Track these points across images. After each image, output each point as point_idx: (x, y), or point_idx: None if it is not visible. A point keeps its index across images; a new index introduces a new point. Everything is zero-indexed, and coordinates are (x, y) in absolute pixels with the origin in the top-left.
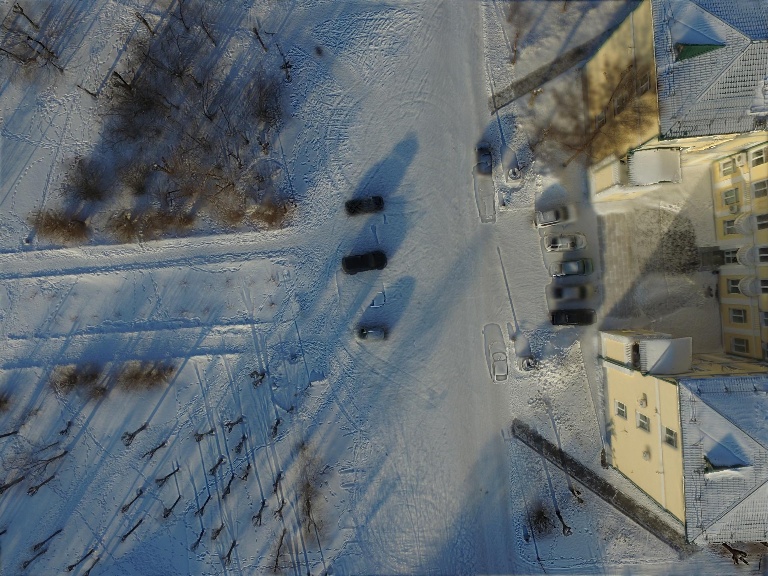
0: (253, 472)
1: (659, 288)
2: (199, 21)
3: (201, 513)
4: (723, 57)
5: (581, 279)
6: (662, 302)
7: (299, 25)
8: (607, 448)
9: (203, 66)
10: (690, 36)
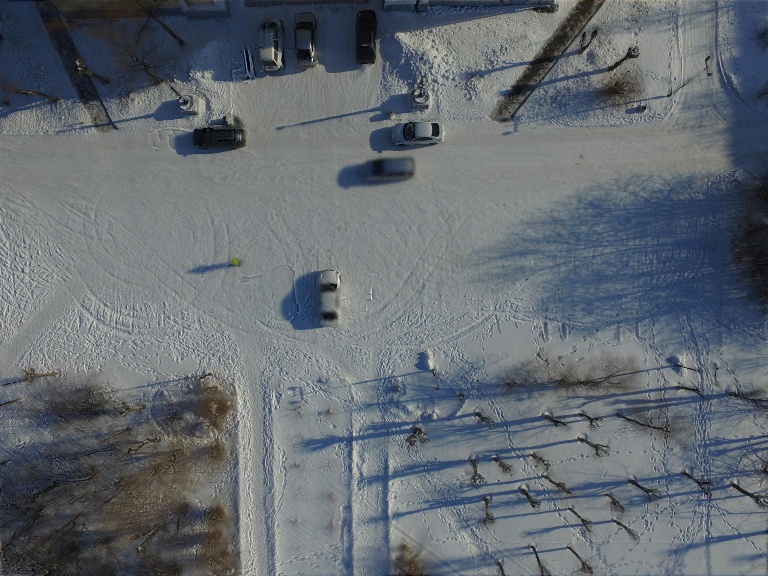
0: (541, 451)
1: None
2: None
3: (588, 524)
4: None
5: (320, 29)
6: None
7: None
8: (531, 5)
9: (33, 478)
10: None
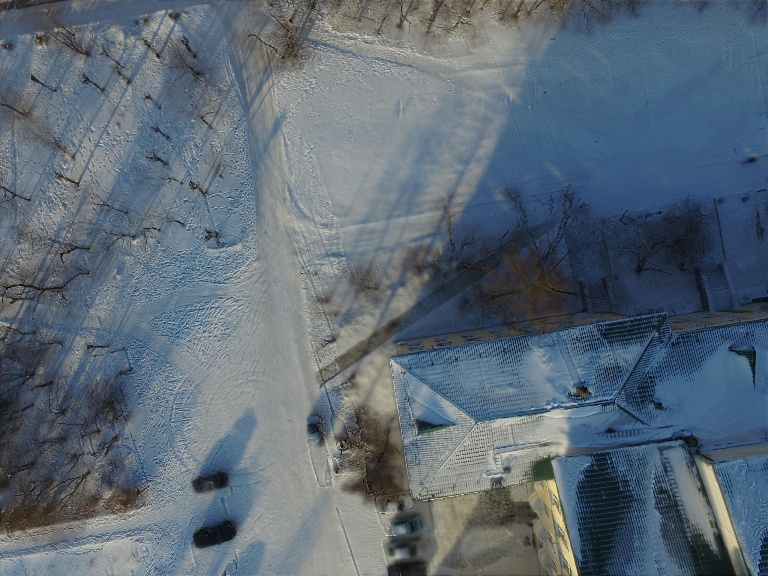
0: None
1: (481, 542)
2: (45, 324)
3: None
4: (455, 434)
5: (414, 533)
6: (486, 553)
7: (137, 320)
8: None
9: (52, 366)
10: (427, 414)
